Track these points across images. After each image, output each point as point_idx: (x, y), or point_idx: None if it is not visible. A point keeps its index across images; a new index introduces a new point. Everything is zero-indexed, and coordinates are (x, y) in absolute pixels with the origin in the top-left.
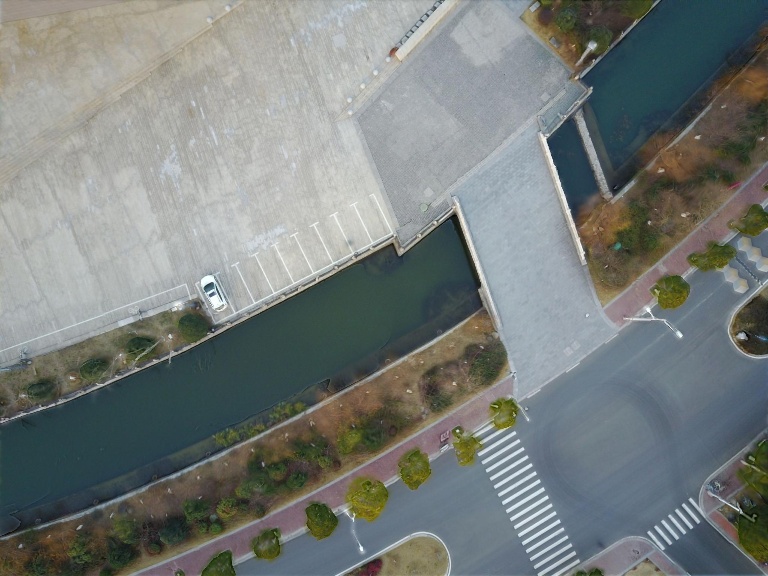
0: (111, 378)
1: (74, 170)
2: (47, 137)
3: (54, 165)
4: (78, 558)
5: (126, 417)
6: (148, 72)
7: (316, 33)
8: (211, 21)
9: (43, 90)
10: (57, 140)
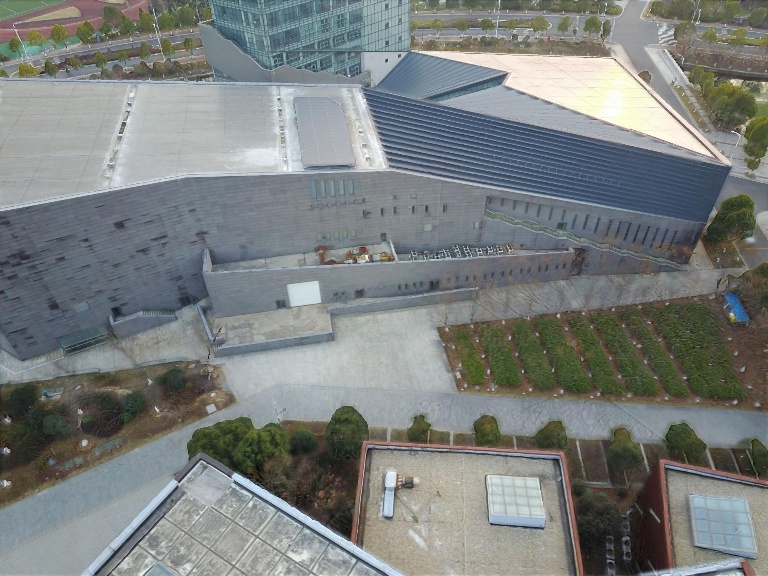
0: None
1: None
2: None
3: None
4: None
5: None
6: None
7: None
8: None
9: None
10: None
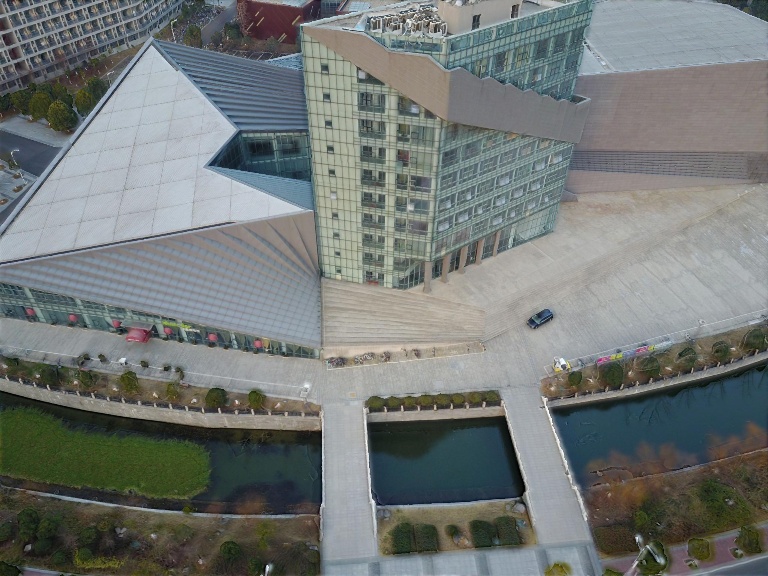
0: (761, 351)
1: (684, 249)
2: (664, 234)
3: (670, 247)
4: None
5: (746, 410)
6: (711, 213)
7: None
8: (739, 195)
9: (655, 215)
10: (668, 236)
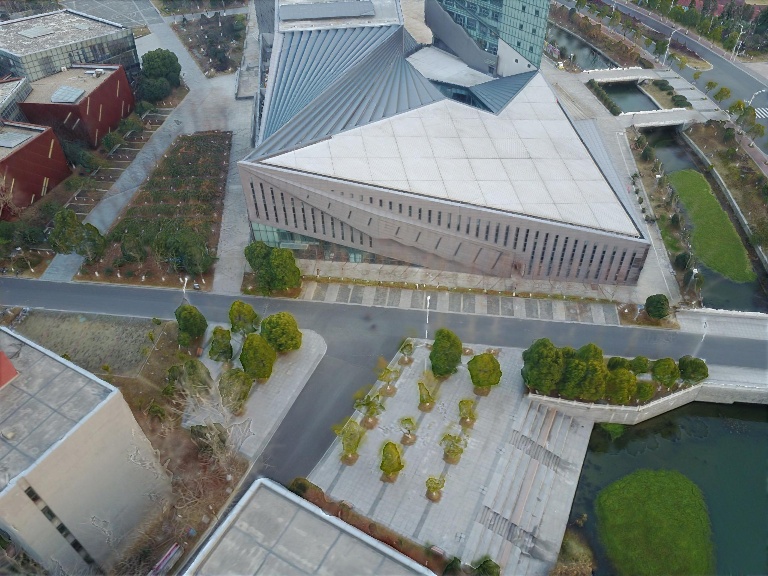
0: None
1: None
2: None
3: None
4: (589, 22)
5: None
6: None
7: (402, 0)
8: None
9: None
10: None
